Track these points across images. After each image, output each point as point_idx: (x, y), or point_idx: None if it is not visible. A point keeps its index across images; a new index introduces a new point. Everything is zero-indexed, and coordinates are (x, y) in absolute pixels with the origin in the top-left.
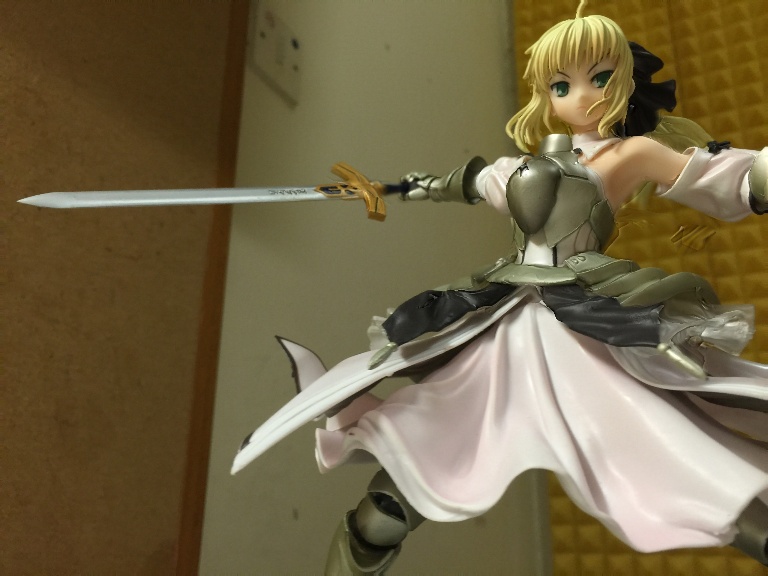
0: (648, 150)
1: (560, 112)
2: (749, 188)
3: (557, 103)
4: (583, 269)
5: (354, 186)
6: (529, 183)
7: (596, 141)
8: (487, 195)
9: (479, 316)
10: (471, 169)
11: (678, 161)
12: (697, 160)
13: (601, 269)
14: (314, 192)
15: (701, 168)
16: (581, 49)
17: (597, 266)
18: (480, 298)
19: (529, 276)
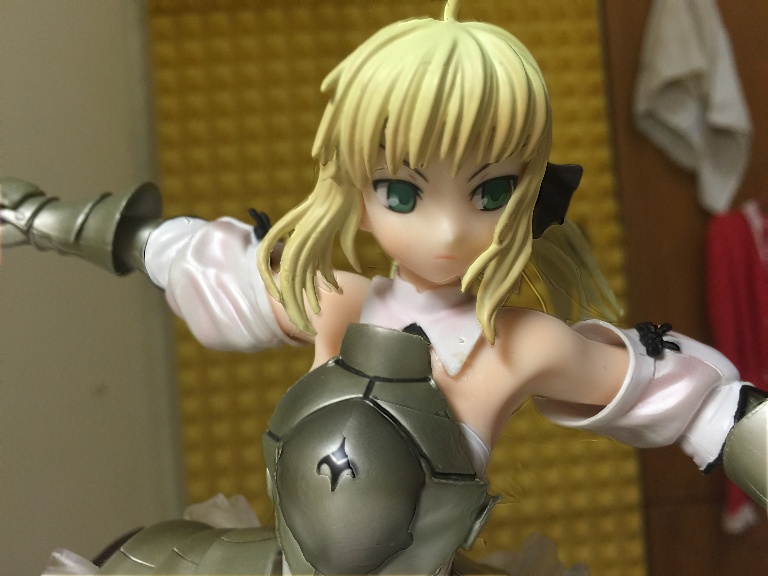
0: (564, 362)
1: (389, 245)
2: (719, 452)
3: (384, 224)
4: None
5: None
6: (348, 494)
7: (453, 311)
8: (174, 301)
9: None
10: (129, 214)
11: (606, 380)
12: (637, 381)
13: None
14: None
15: (639, 393)
16: (474, 131)
17: None
18: None
19: None
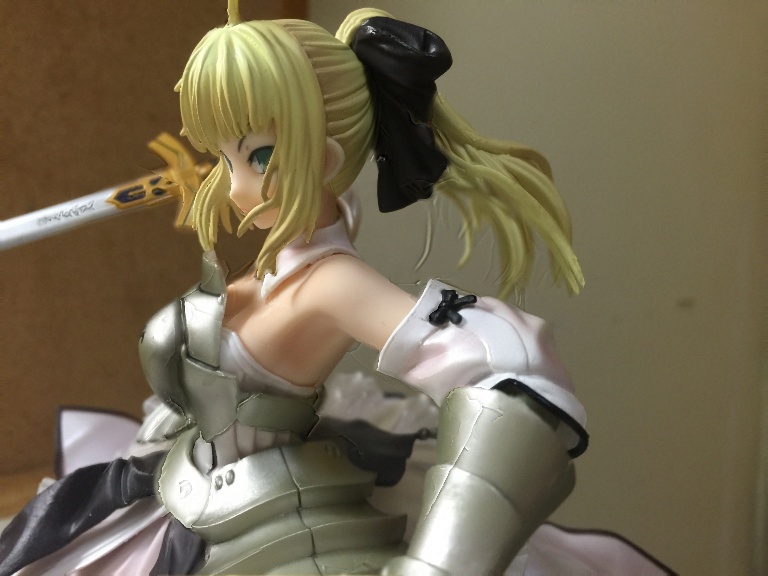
0: (329, 307)
1: None
2: None
3: (231, 181)
4: (211, 512)
5: (171, 177)
6: (156, 353)
7: (291, 252)
8: None
9: (153, 500)
10: None
11: (375, 334)
12: (400, 341)
13: (226, 523)
14: (106, 204)
15: (409, 355)
16: (204, 117)
17: (231, 509)
18: (140, 488)
19: (169, 489)
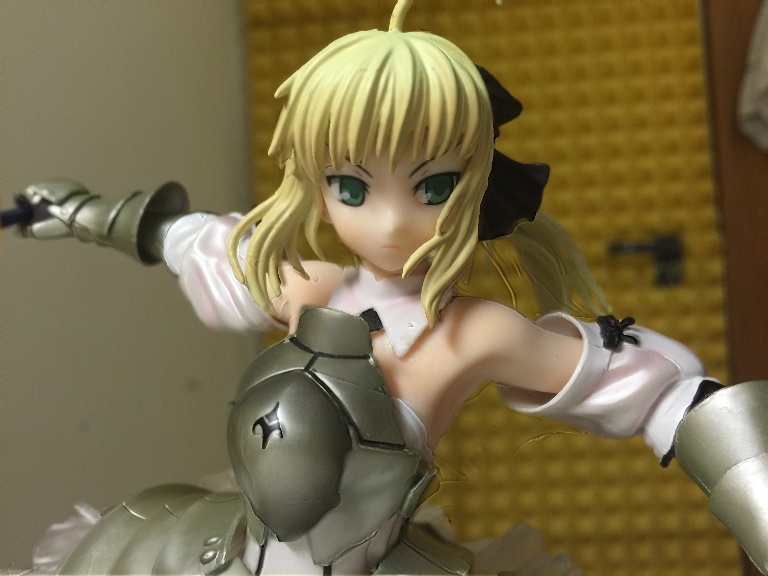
0: (510, 349)
1: (343, 235)
2: (671, 444)
3: (338, 216)
4: None
5: None
6: (281, 453)
7: (409, 299)
8: (184, 288)
9: None
10: (154, 210)
11: (557, 369)
12: (589, 371)
13: None
14: None
15: (592, 383)
16: (405, 131)
17: None
18: None
19: None
